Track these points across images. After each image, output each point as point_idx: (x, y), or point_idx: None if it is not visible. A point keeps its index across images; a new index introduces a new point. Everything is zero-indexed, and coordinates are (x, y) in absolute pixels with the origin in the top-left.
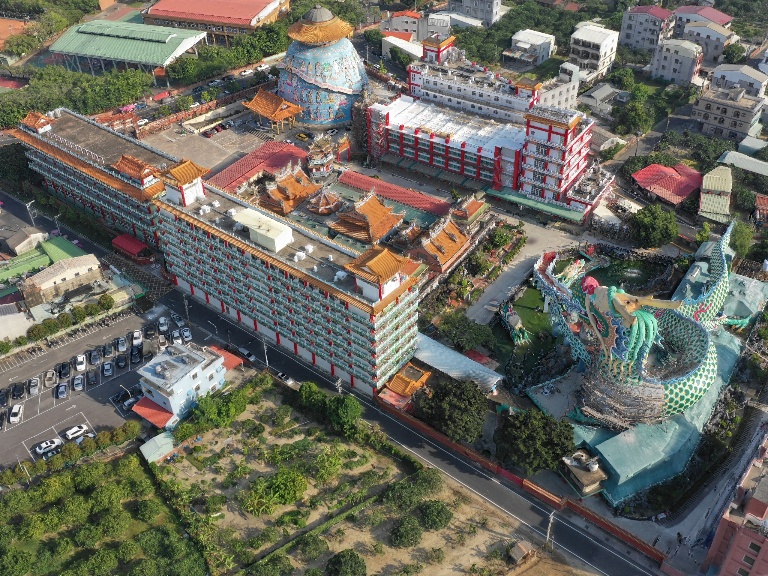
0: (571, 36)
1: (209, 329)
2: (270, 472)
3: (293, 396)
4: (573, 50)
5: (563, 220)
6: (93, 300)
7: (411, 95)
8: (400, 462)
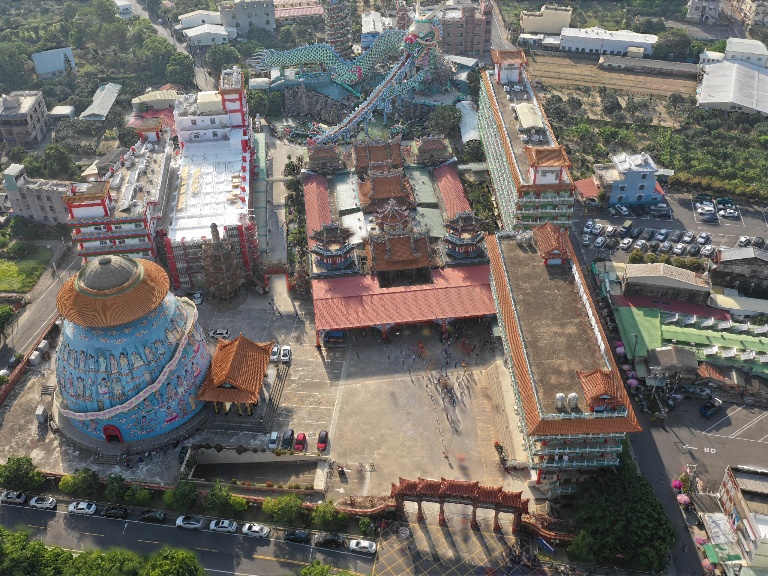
0: None
1: None
2: None
3: None
4: None
5: None
6: None
7: None
8: None
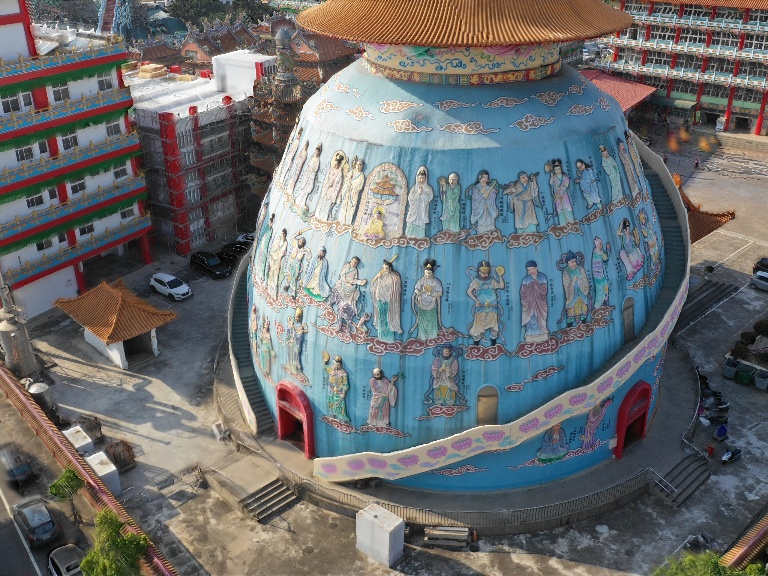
0: None
1: None
2: None
3: None
4: None
5: None
6: None
7: None
8: None
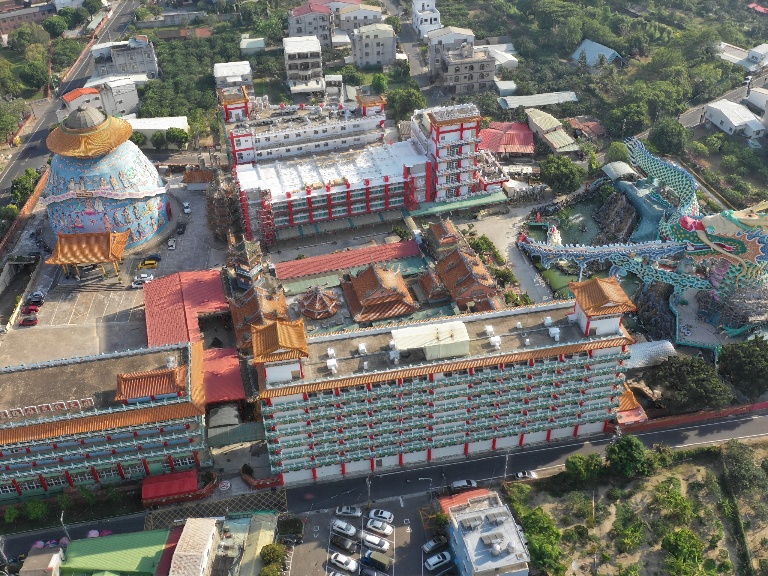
0: (286, 53)
1: (389, 495)
2: (644, 555)
3: (554, 483)
4: (289, 66)
5: (482, 207)
6: (244, 568)
7: (238, 163)
8: (692, 460)
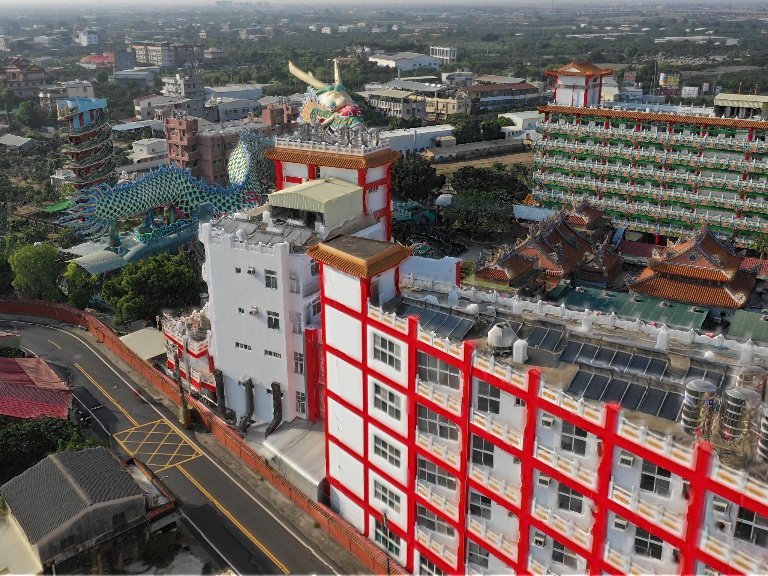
0: None
1: None
2: None
3: None
4: None
5: None
6: None
7: None
8: None
